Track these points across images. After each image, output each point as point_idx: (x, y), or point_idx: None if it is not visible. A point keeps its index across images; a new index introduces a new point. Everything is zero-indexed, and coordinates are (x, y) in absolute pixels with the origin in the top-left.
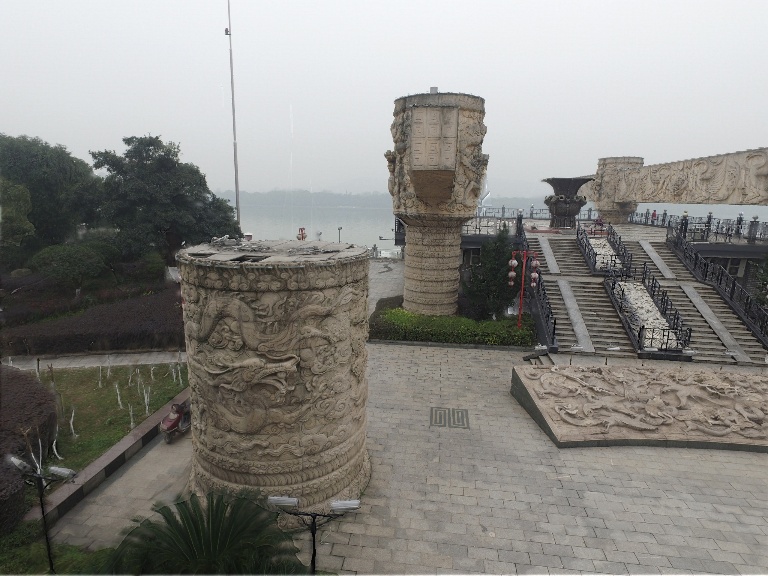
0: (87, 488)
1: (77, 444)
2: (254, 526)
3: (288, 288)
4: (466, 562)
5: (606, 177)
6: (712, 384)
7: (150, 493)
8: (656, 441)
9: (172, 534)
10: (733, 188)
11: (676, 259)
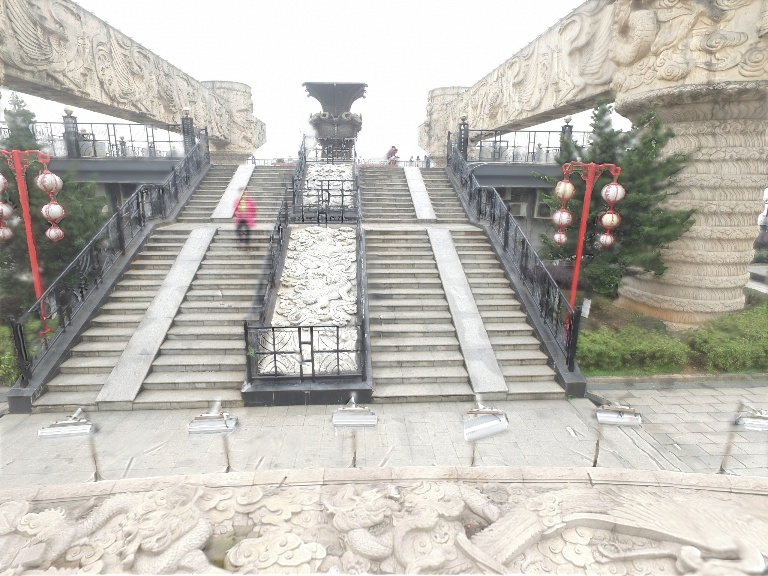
0: None
1: None
2: None
3: None
4: None
5: (434, 114)
6: (241, 569)
7: None
8: None
9: None
10: (545, 86)
11: (451, 190)
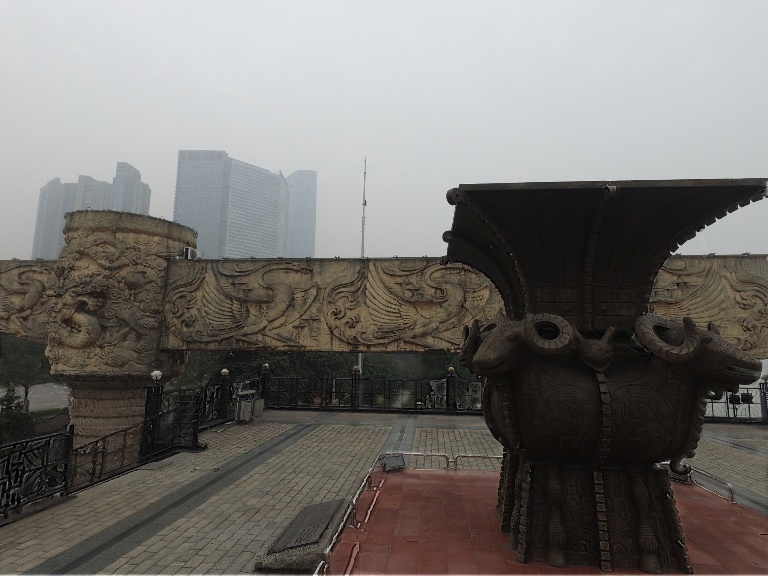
0: None
1: None
2: None
3: None
4: None
5: None
6: None
7: None
8: None
9: None
10: None
11: None
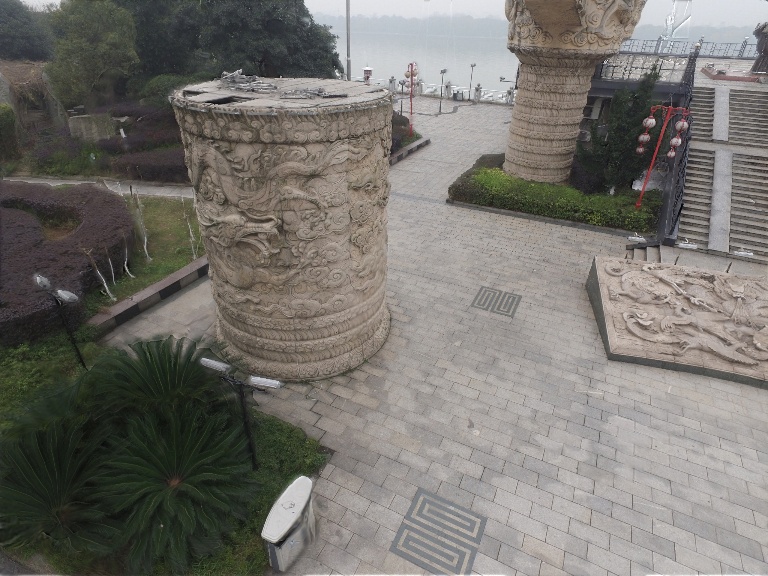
0: (143, 306)
1: (148, 266)
2: (201, 377)
3: (261, 140)
4: (434, 452)
5: None
6: None
7: (189, 320)
8: (747, 378)
9: (139, 367)
10: None
11: None
